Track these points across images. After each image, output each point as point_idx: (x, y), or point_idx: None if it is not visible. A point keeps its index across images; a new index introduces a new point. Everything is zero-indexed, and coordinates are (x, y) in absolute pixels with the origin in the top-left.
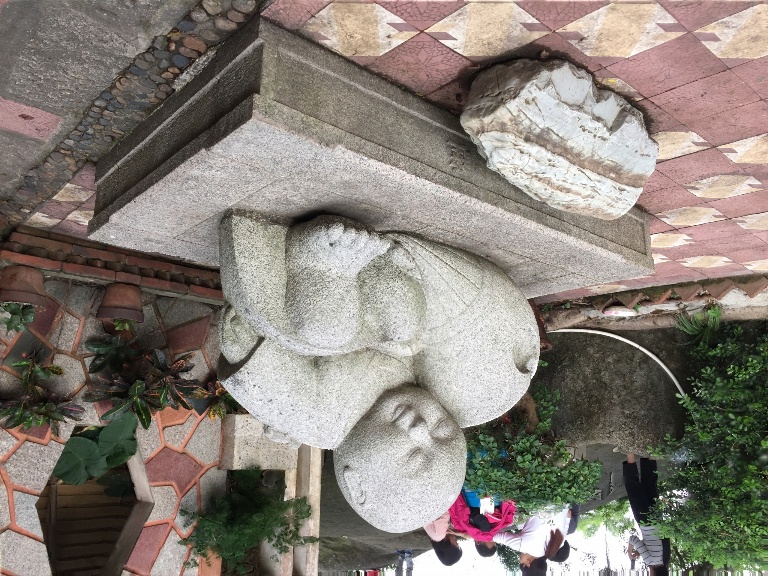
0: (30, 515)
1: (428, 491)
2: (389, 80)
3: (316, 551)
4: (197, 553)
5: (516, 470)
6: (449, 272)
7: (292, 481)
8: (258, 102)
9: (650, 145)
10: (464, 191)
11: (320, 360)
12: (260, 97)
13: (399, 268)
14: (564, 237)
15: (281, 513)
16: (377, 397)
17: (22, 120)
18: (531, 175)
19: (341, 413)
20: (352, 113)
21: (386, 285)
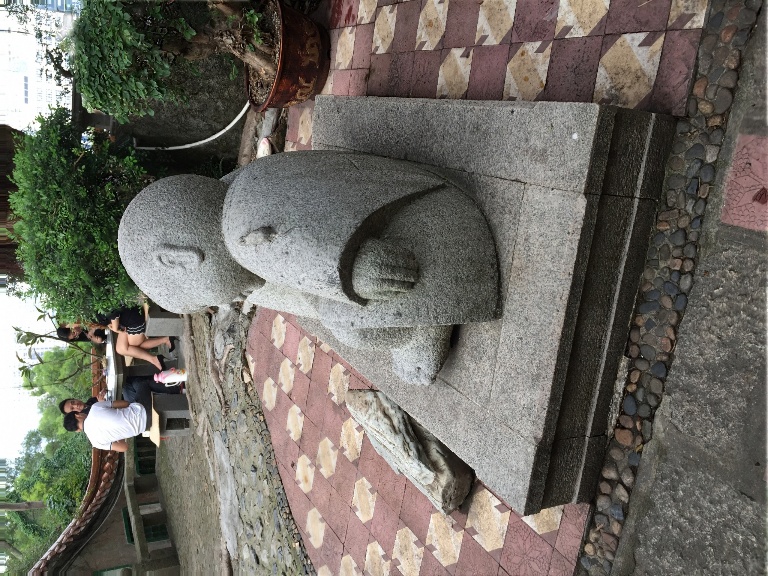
0: None
1: None
2: None
3: None
4: None
5: None
6: None
7: None
8: None
9: None
10: None
11: None
12: None
13: None
14: None
15: None
16: None
17: (767, 183)
18: None
19: None
20: None
21: None
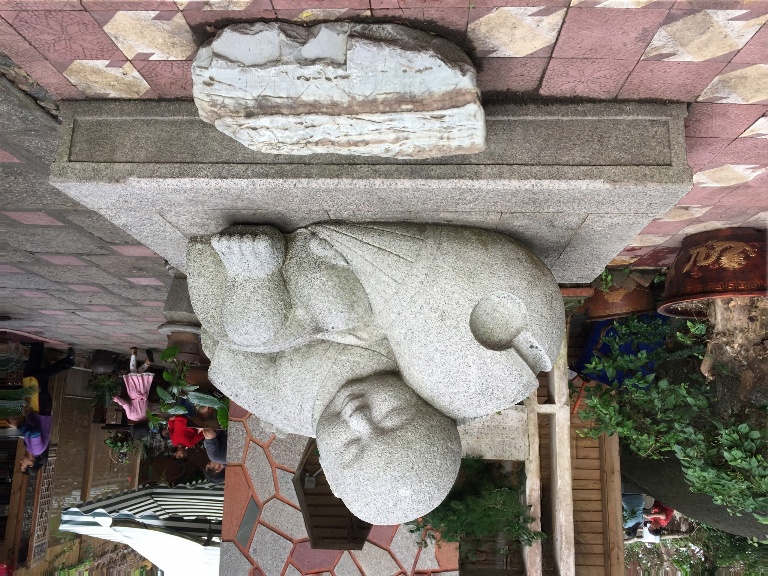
0: (289, 488)
1: (362, 483)
2: (191, 99)
3: (571, 549)
4: (430, 534)
5: (734, 470)
6: (371, 252)
7: (534, 472)
8: (53, 168)
9: (414, 57)
10: (288, 175)
11: (277, 356)
12: (55, 164)
13: (321, 258)
14: (469, 183)
15: (487, 503)
16: (339, 387)
17: None
18: (301, 143)
19: (302, 404)
20: (150, 144)
21: (305, 278)
